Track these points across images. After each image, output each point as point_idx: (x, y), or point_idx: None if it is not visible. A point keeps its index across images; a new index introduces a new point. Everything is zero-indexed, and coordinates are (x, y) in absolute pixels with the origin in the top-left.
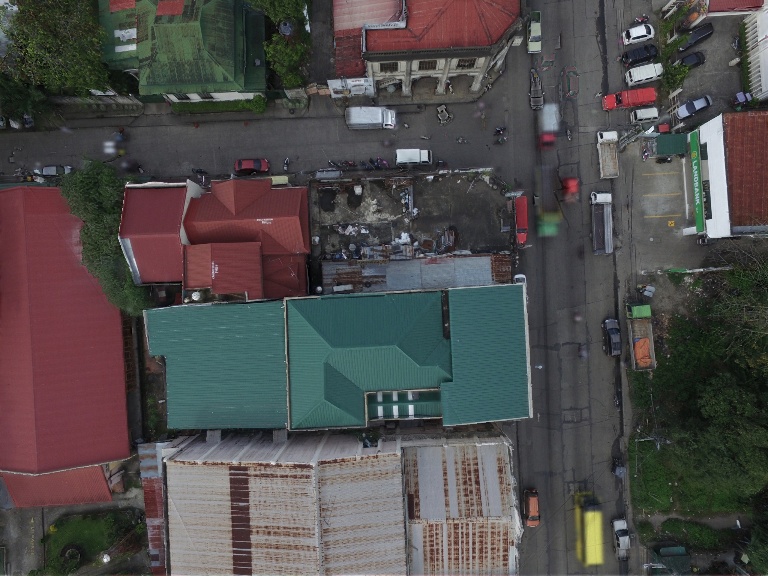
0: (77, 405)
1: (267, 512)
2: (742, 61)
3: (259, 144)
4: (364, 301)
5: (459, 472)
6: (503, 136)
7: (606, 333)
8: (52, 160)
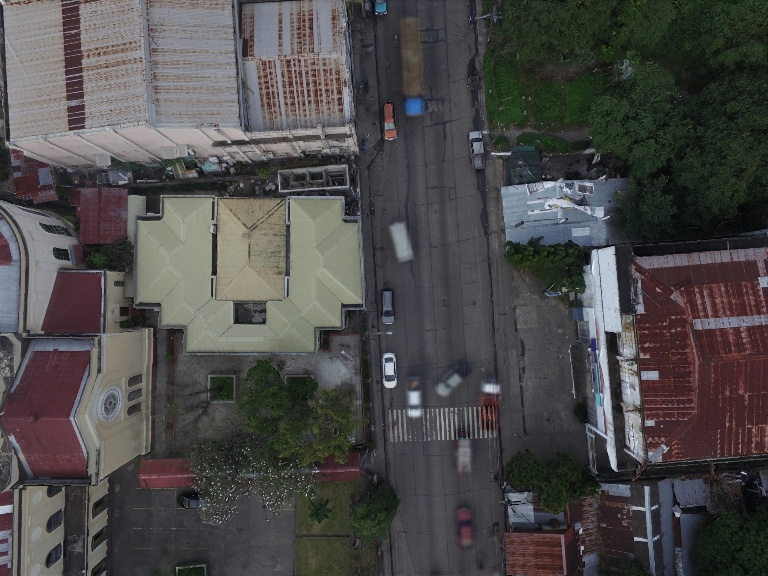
0: None
1: (97, 34)
2: None
3: None
4: None
5: (294, 21)
6: None
7: None
8: None
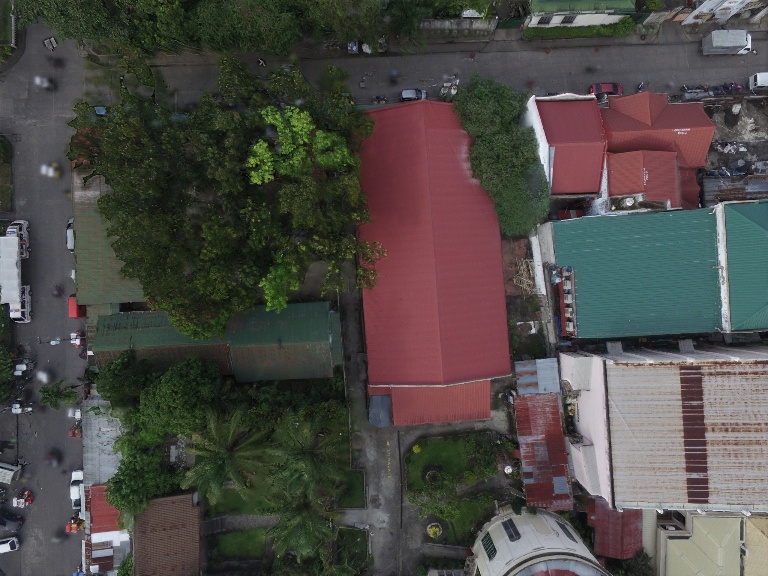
0: (471, 319)
1: (724, 409)
2: None
3: (610, 70)
4: None
5: None
6: None
7: None
8: (405, 85)
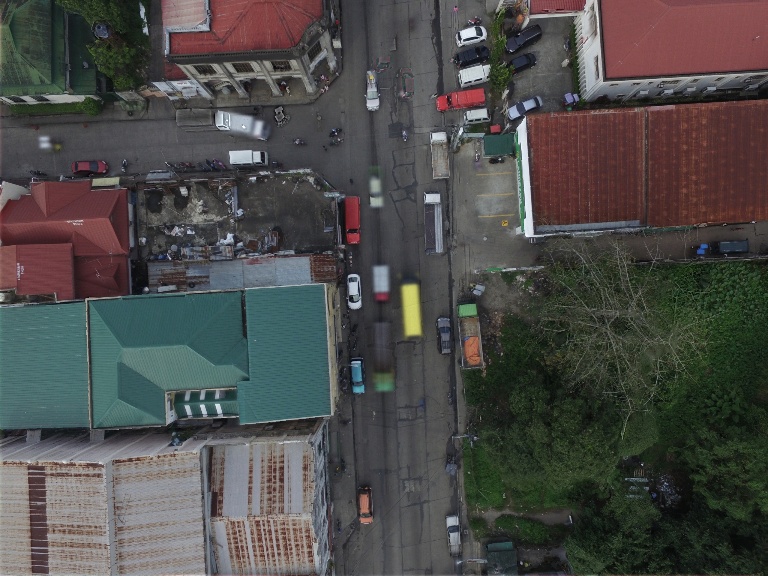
0: None
1: (62, 511)
2: (572, 62)
3: (98, 146)
4: (164, 301)
5: (264, 470)
6: (337, 137)
7: (438, 332)
8: None
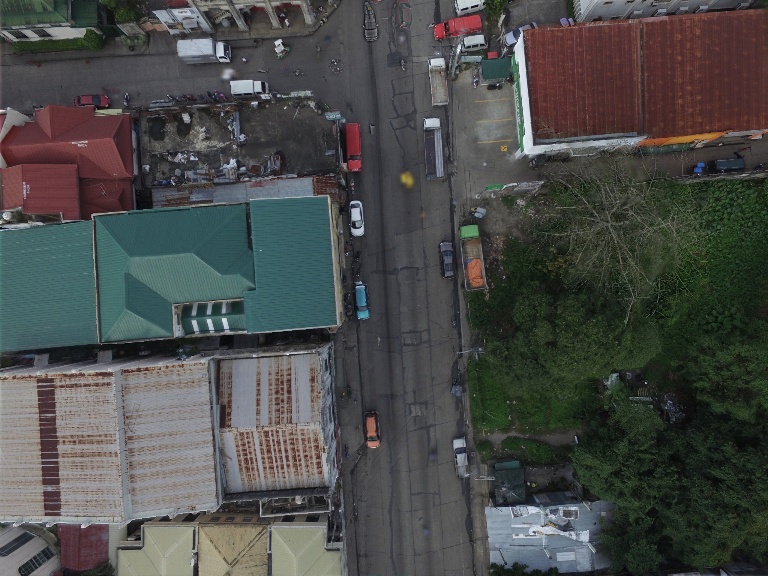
0: None
1: (72, 422)
2: None
3: (100, 81)
4: (170, 215)
5: (272, 382)
6: (337, 67)
7: (440, 255)
8: None
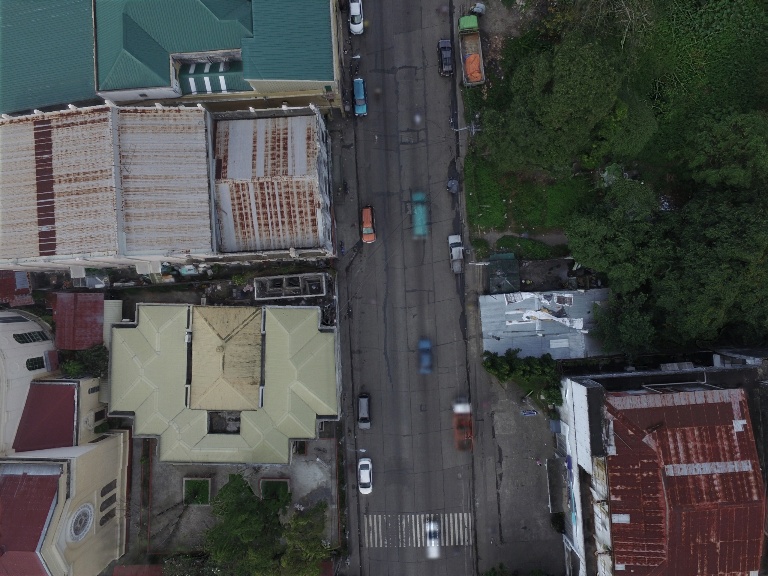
0: None
1: (68, 160)
2: None
3: None
4: None
5: (268, 140)
6: None
7: (439, 52)
8: None
